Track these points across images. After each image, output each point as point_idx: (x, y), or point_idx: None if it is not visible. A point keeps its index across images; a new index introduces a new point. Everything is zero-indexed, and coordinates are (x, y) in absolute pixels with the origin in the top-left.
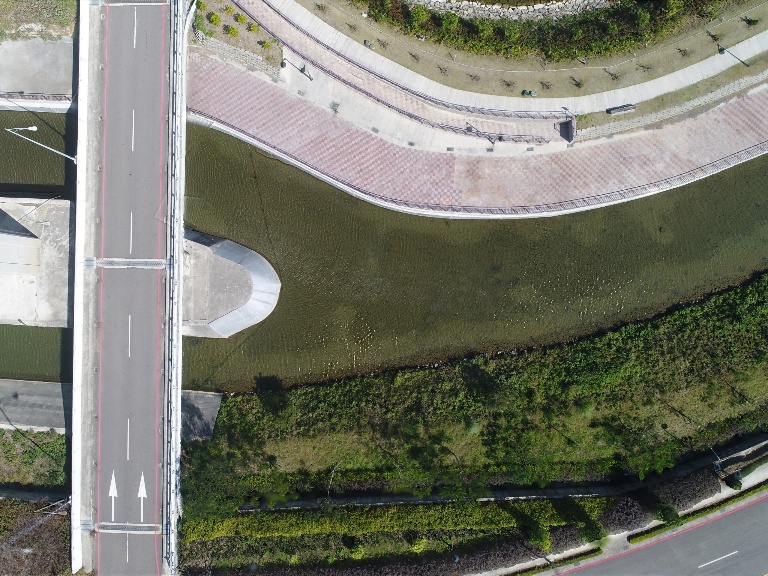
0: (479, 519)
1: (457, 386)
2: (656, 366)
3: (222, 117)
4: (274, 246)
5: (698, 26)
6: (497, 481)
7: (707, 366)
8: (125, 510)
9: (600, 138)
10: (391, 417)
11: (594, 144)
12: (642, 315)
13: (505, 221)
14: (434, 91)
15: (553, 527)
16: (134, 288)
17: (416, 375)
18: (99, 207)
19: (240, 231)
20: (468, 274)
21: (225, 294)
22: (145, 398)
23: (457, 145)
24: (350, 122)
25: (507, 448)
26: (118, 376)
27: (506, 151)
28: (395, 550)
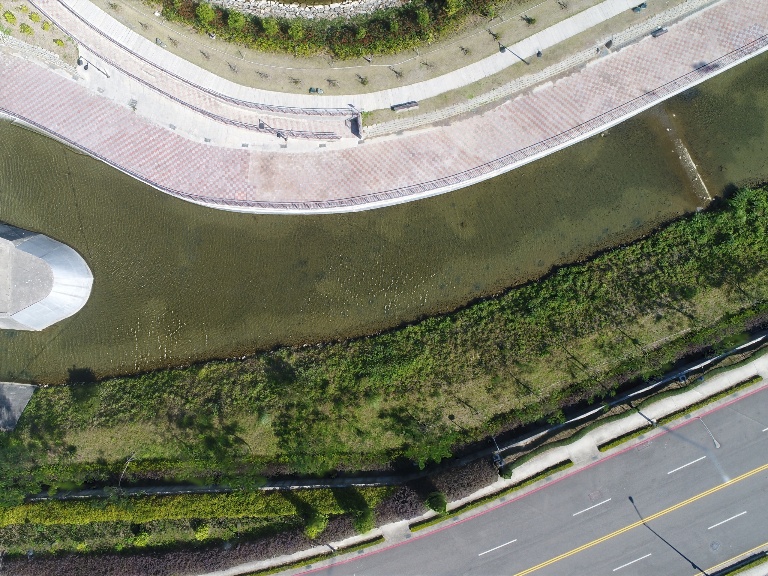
0: (261, 507)
1: (258, 378)
2: (447, 358)
3: (24, 114)
4: (87, 240)
5: (480, 25)
6: (287, 471)
7: (495, 358)
8: None
9: (390, 135)
10: (189, 408)
11: (384, 140)
12: (444, 309)
13: (311, 216)
14: (224, 88)
15: (333, 515)
16: None
17: (222, 367)
18: None
19: (54, 226)
20: (276, 268)
21: (27, 287)
22: None
23: (251, 141)
24: (148, 119)
25: (299, 438)
26: None
27: (299, 147)
28: (182, 538)
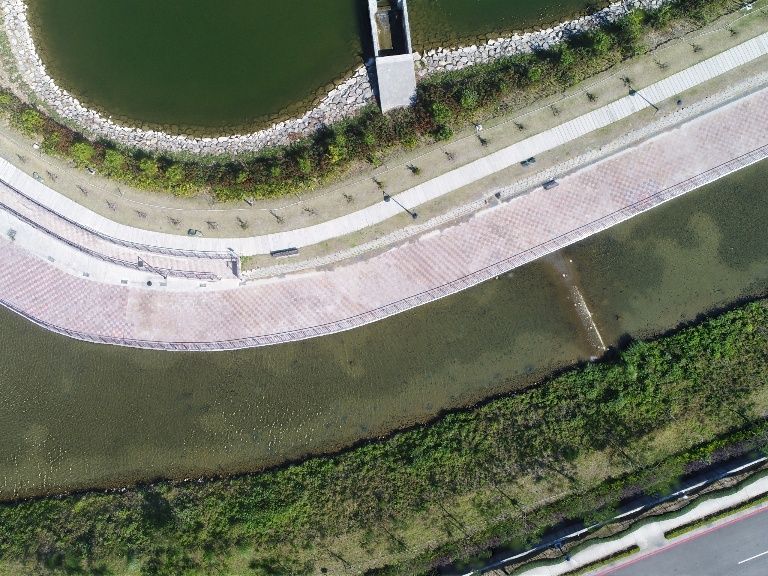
0: None
1: (133, 515)
2: (324, 507)
3: None
4: None
5: (365, 172)
6: None
7: (372, 511)
8: None
9: (272, 277)
10: (60, 546)
11: (266, 283)
12: (329, 448)
13: None
14: (101, 226)
15: None
16: None
17: (100, 500)
18: None
19: None
20: (160, 399)
21: None
22: None
23: (131, 278)
24: (27, 250)
25: None
26: None
27: (179, 286)
28: None
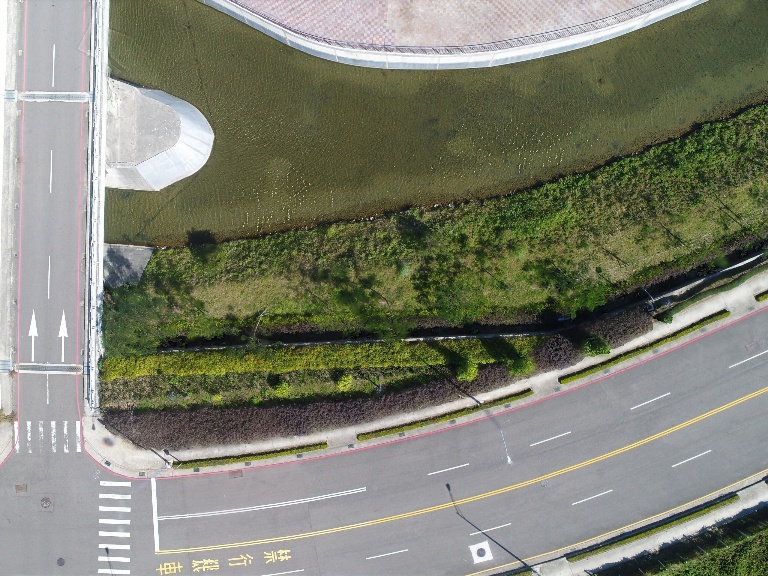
0: (407, 356)
1: (391, 235)
2: (592, 211)
3: None
4: (208, 97)
5: None
6: (428, 324)
7: (643, 210)
8: (45, 350)
9: None
10: (322, 263)
11: None
12: (581, 168)
13: (443, 72)
14: None
15: (482, 365)
16: (56, 122)
17: (350, 227)
18: (21, 39)
19: (173, 82)
20: (405, 126)
21: (153, 136)
22: (67, 235)
23: None
24: None
25: (439, 292)
26: (39, 212)
27: None
28: (322, 390)
